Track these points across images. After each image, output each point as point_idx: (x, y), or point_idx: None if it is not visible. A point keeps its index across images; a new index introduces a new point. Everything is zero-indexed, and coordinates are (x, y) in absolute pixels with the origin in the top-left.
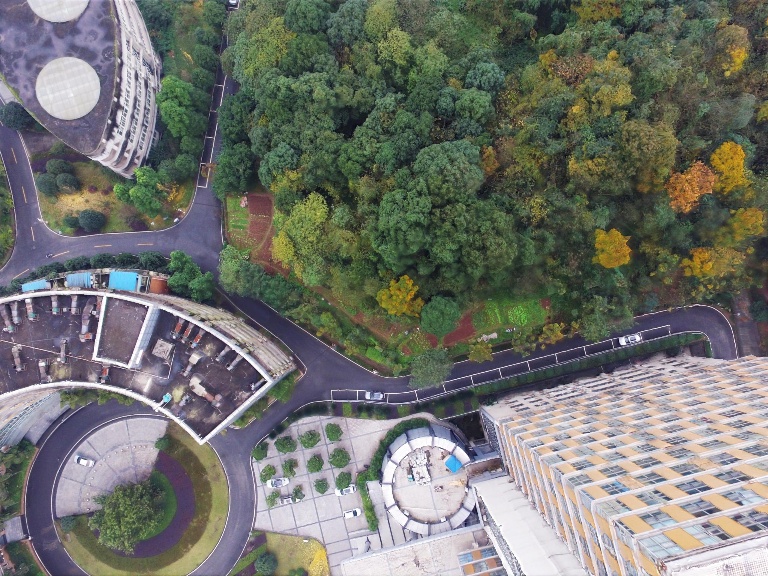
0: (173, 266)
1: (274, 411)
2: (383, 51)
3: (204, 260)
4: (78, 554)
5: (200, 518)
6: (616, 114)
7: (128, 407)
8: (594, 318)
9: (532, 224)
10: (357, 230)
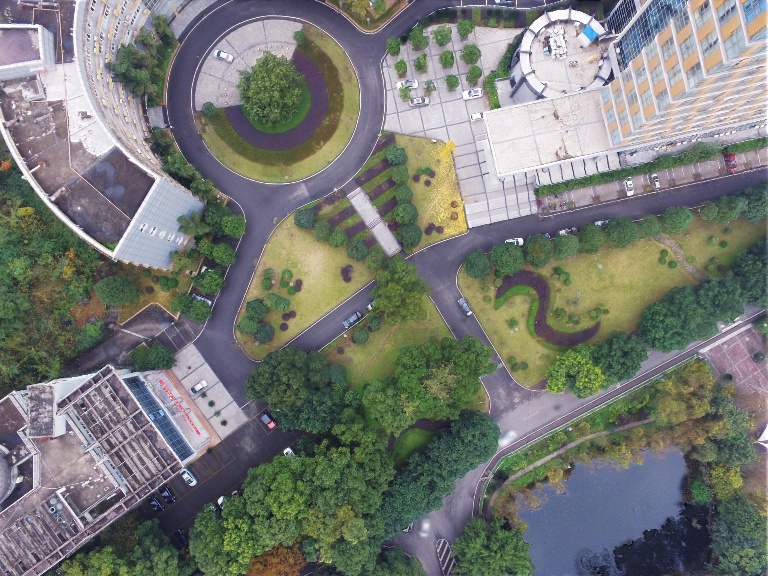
0: None
1: (404, 18)
2: None
3: None
4: (216, 146)
5: (332, 117)
6: None
7: (265, 8)
8: None
9: None
10: None
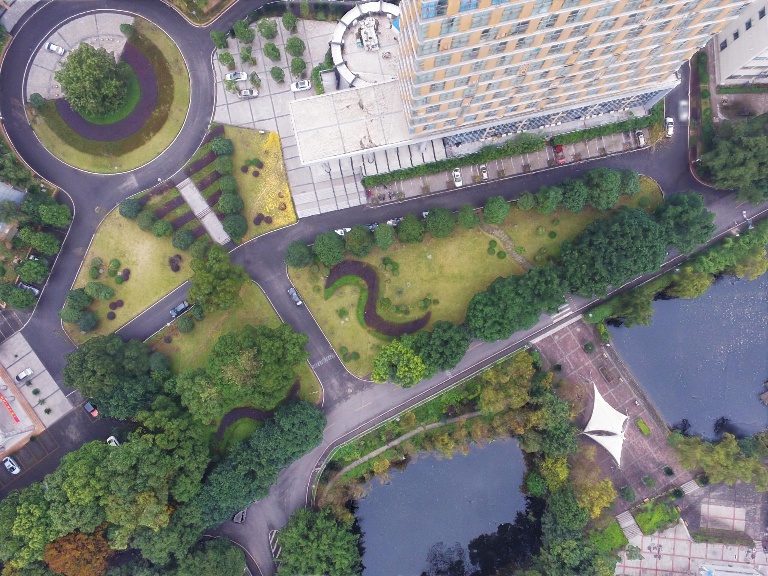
0: None
1: (235, 12)
2: None
3: None
4: (46, 137)
5: (162, 109)
6: None
7: (97, 2)
8: None
9: None
10: None
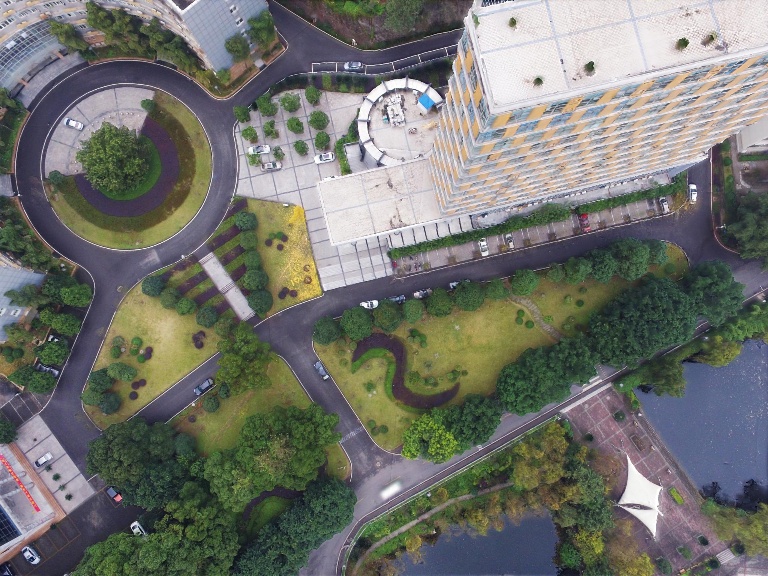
0: None
1: (257, 84)
2: None
3: None
4: (65, 213)
5: (184, 183)
6: None
7: (117, 76)
8: None
9: None
10: None
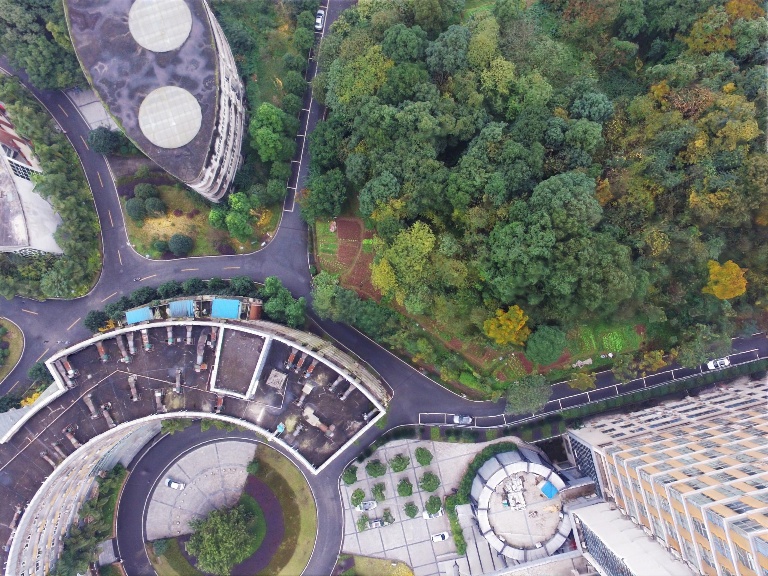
0: (268, 292)
1: None
2: (487, 81)
3: (291, 284)
4: None
5: (289, 541)
6: (740, 148)
7: (217, 430)
8: (694, 345)
9: (648, 256)
10: (463, 259)
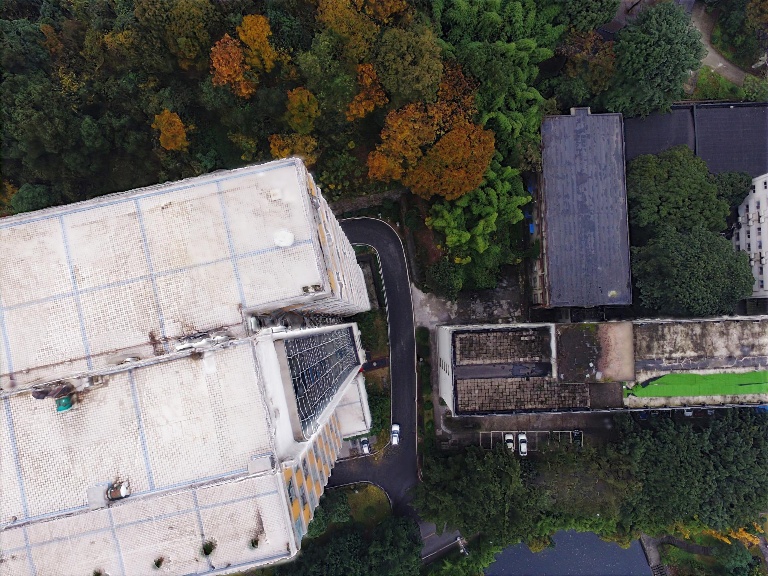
0: None
1: None
2: None
3: None
4: None
5: None
6: None
7: None
8: None
9: (86, 103)
10: None
